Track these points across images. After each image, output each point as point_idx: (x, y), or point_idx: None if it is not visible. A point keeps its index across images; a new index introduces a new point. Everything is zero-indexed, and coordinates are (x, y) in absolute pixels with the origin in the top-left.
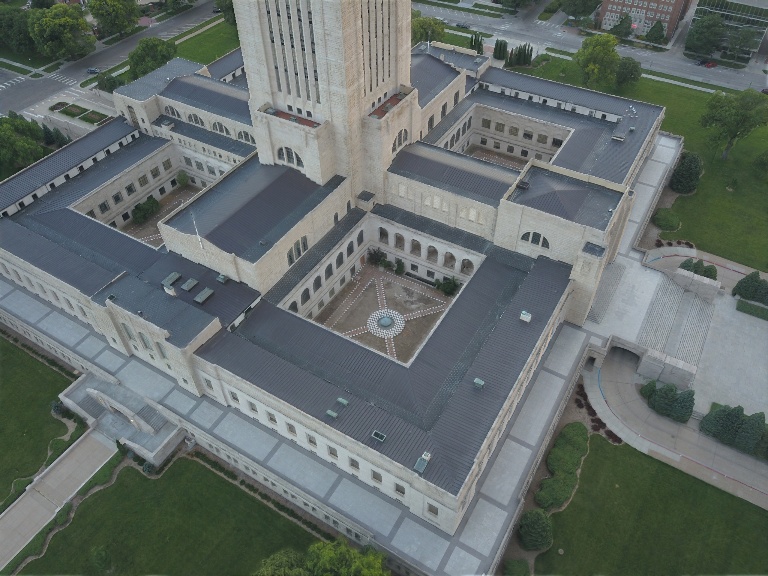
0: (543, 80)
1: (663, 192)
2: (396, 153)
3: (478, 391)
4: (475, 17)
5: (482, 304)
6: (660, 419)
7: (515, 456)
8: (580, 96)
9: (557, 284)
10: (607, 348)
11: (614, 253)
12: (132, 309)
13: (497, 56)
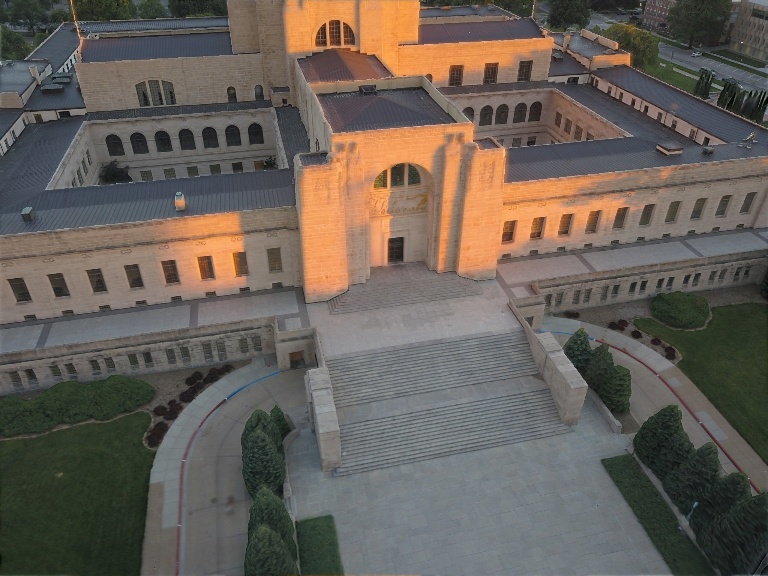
0: (671, 88)
1: (738, 287)
2: (325, 48)
3: (19, 221)
4: (763, 80)
5: (203, 194)
6: (240, 470)
7: (16, 340)
8: (698, 111)
9: (276, 204)
10: (286, 335)
11: (459, 253)
12: (1, 72)
13: (720, 104)
